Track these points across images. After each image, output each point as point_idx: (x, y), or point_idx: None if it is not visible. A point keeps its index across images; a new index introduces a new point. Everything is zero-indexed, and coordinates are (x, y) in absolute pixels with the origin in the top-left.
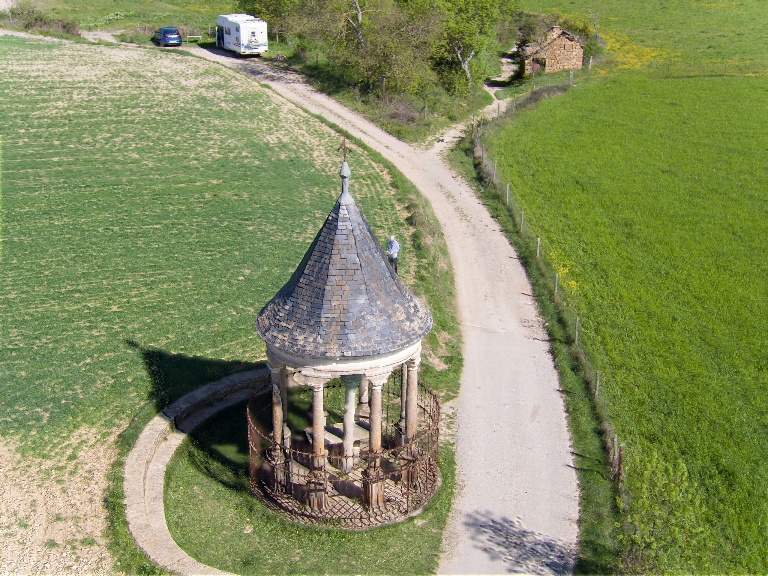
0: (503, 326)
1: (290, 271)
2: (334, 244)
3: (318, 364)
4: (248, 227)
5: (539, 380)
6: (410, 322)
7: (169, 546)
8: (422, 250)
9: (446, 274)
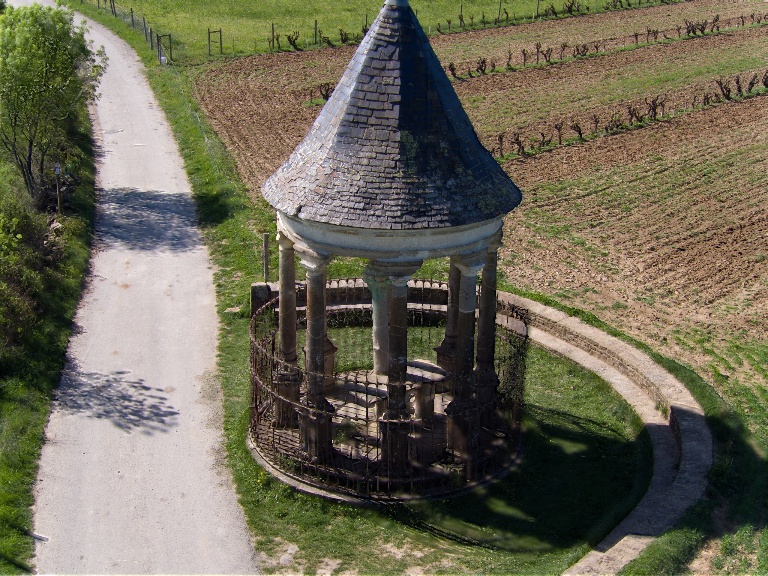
0: None
1: None
2: None
3: None
4: None
5: None
6: None
7: None
8: None
9: None
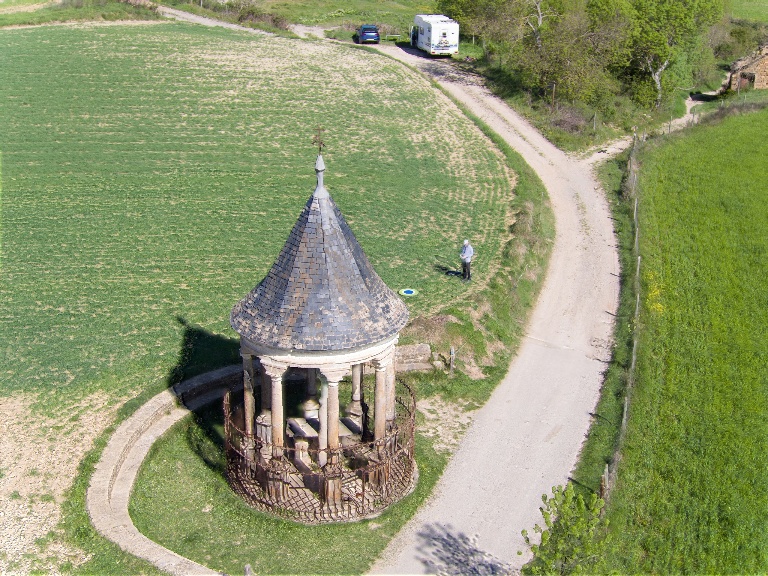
0: (568, 343)
1: None
2: (302, 237)
3: (275, 354)
4: (349, 221)
5: (576, 401)
6: (373, 322)
7: (120, 513)
8: (508, 258)
9: (532, 285)
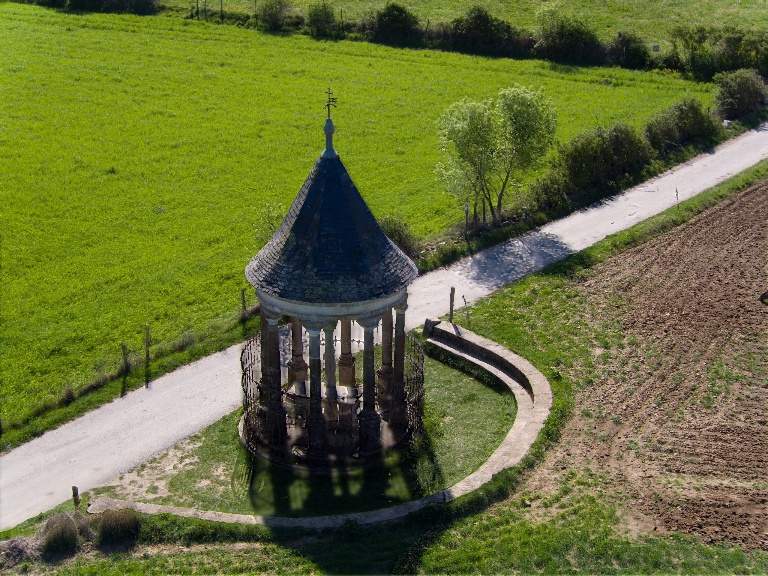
0: None
1: None
2: None
3: None
4: None
5: None
6: None
7: (525, 404)
8: None
9: None
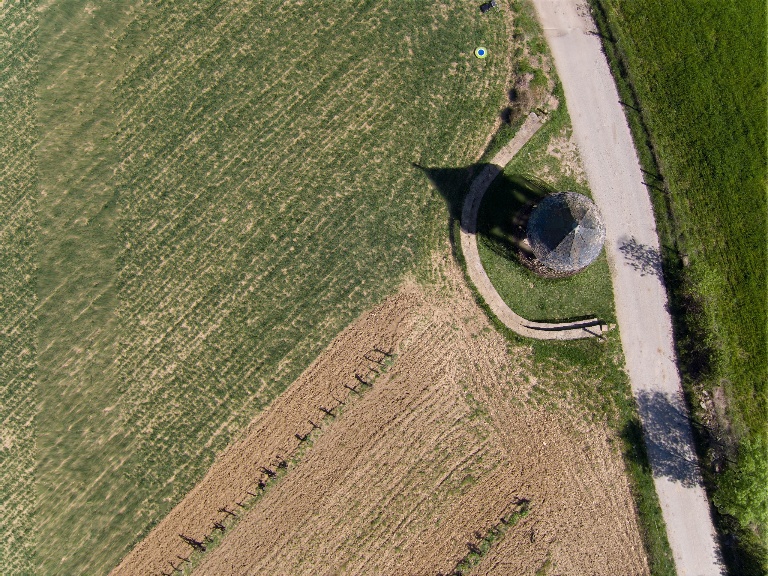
0: (568, 22)
1: (434, 29)
2: (573, 241)
3: None
4: None
5: (607, 93)
6: None
7: (514, 316)
8: None
9: None
